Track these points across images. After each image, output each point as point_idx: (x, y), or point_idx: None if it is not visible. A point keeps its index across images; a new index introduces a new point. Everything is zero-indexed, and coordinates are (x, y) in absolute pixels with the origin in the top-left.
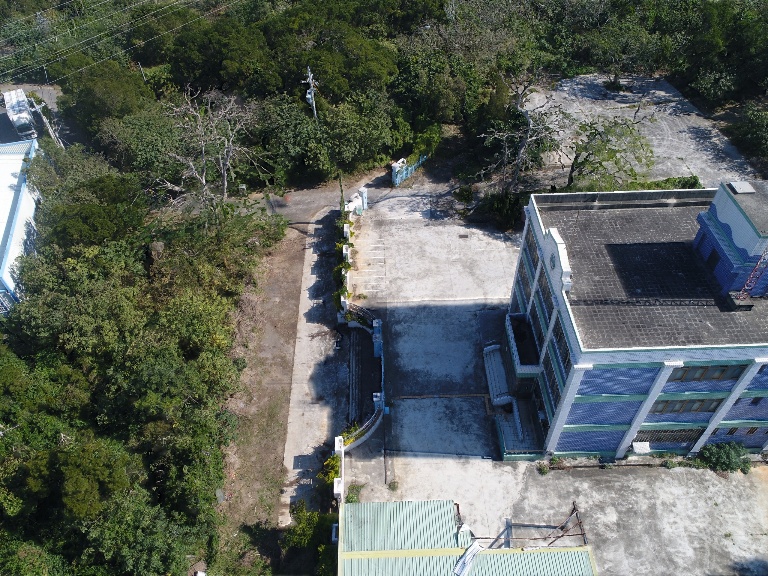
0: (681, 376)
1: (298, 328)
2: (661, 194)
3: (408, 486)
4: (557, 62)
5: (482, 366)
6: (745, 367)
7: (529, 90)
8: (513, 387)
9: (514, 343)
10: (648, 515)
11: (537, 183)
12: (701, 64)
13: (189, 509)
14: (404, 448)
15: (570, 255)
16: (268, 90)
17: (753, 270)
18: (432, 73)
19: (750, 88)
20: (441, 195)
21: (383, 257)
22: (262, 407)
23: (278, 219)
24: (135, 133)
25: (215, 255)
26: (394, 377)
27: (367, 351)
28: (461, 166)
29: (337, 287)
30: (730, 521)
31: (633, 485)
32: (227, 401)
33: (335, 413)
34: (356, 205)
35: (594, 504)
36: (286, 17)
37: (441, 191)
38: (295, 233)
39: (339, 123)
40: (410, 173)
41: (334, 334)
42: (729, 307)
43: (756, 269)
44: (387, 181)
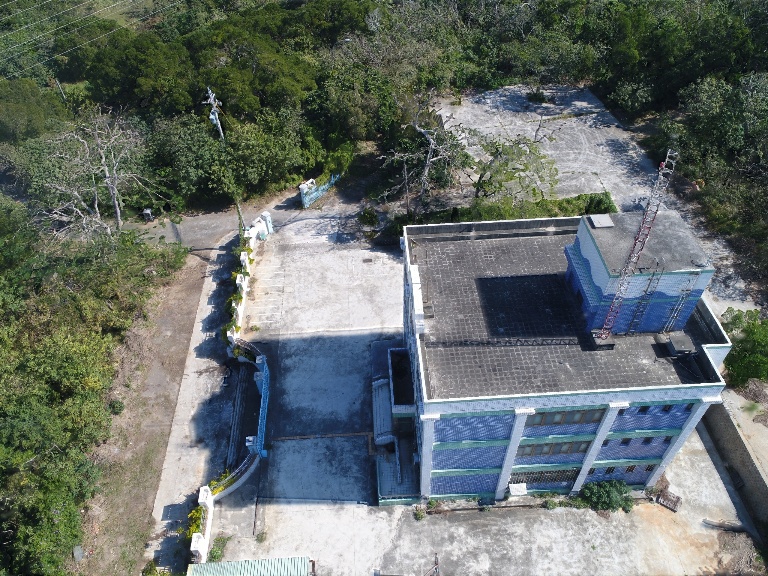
0: (540, 421)
1: (186, 364)
2: (539, 223)
3: (277, 537)
4: (481, 73)
5: (370, 402)
6: (604, 411)
7: (451, 103)
8: (393, 426)
9: (391, 381)
10: (522, 561)
11: (448, 202)
12: (622, 74)
13: (33, 574)
14: (278, 494)
15: (437, 291)
16: (177, 109)
17: (610, 309)
18: (345, 89)
19: (671, 98)
20: (350, 216)
21: (282, 285)
22: (138, 452)
23: (176, 247)
24: (33, 158)
25: (101, 289)
26: (277, 416)
27: (253, 388)
28: (373, 185)
29: (230, 319)
30: (606, 565)
31: (510, 529)
32: (99, 448)
33: (213, 457)
34: (259, 230)
35: (468, 551)
36: (211, 30)
37: (351, 212)
38: (196, 260)
39: (242, 145)
40: (321, 193)
41: (223, 370)
42: (591, 346)
43: (614, 307)
44: (297, 202)
